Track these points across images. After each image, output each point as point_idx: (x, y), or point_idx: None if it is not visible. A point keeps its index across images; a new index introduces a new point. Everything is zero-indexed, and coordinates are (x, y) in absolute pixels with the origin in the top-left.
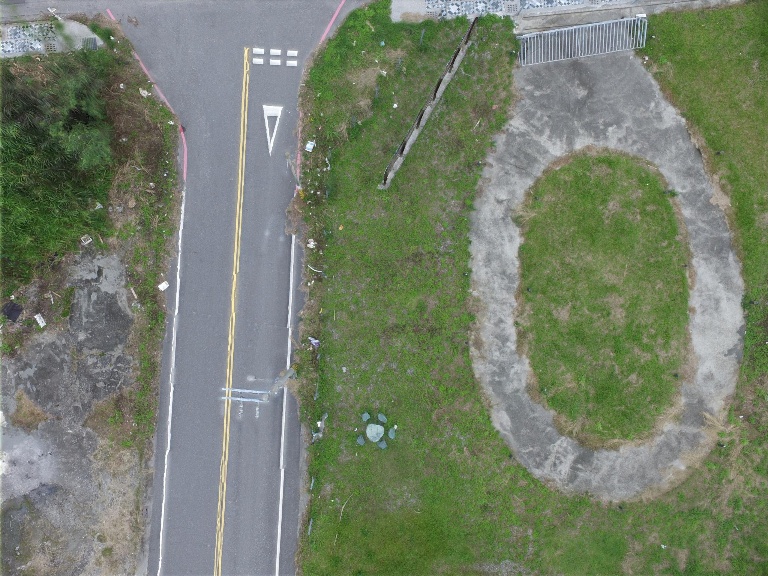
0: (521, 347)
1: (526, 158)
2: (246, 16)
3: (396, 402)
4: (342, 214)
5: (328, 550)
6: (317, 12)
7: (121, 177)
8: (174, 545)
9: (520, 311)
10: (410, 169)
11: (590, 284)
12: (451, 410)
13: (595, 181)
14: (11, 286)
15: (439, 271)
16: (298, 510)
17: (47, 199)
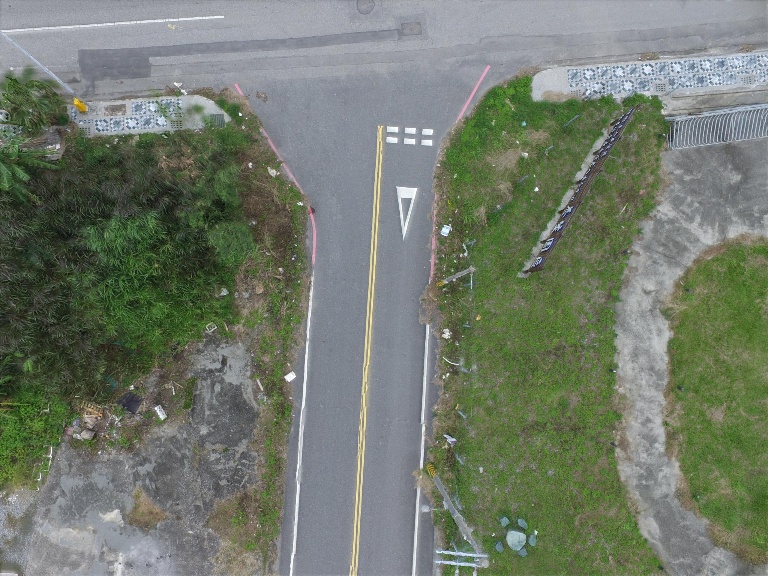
0: (670, 449)
1: (675, 246)
2: (380, 93)
3: (537, 506)
4: (480, 303)
5: None
6: (454, 89)
7: (249, 262)
8: None
9: (670, 410)
10: (552, 256)
11: (746, 384)
12: (595, 516)
13: (749, 272)
14: (132, 377)
15: (583, 366)
16: None
17: (181, 291)
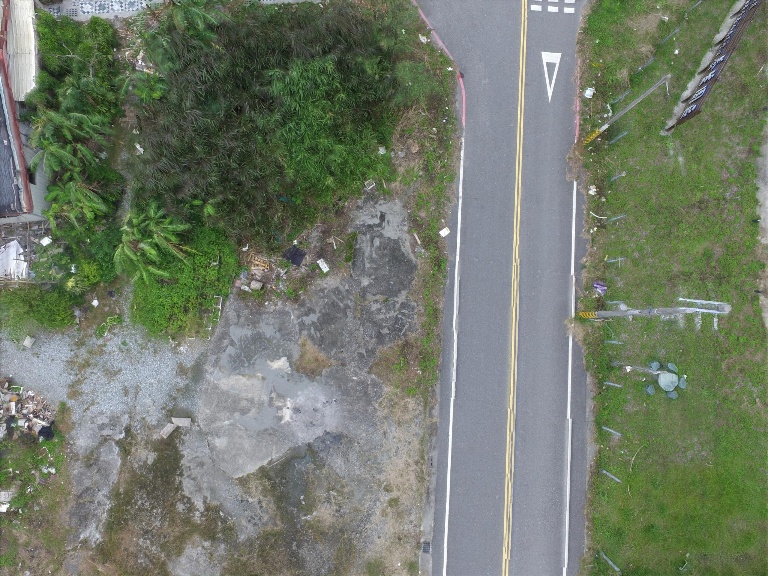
0: None
1: None
2: None
3: (685, 351)
4: (625, 160)
5: (619, 503)
6: None
7: (405, 122)
8: (461, 496)
9: None
10: None
11: None
12: (742, 360)
13: None
14: (298, 230)
15: (726, 218)
16: (586, 462)
17: (354, 138)
